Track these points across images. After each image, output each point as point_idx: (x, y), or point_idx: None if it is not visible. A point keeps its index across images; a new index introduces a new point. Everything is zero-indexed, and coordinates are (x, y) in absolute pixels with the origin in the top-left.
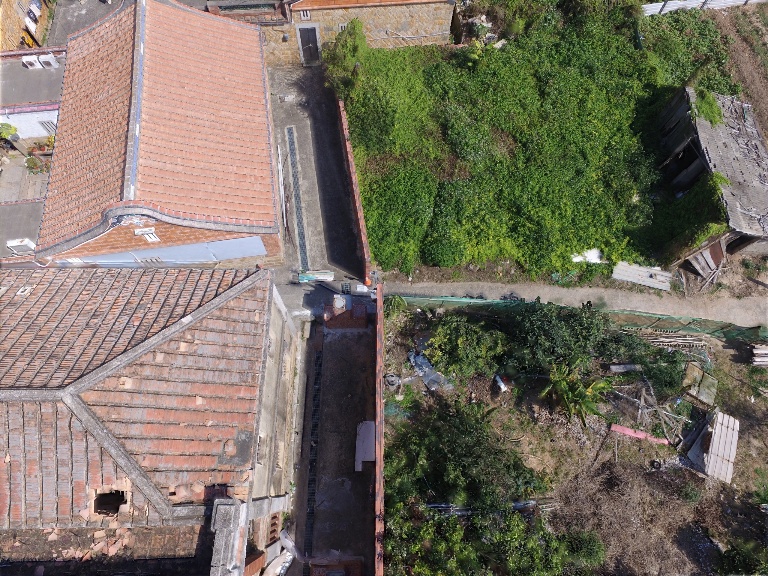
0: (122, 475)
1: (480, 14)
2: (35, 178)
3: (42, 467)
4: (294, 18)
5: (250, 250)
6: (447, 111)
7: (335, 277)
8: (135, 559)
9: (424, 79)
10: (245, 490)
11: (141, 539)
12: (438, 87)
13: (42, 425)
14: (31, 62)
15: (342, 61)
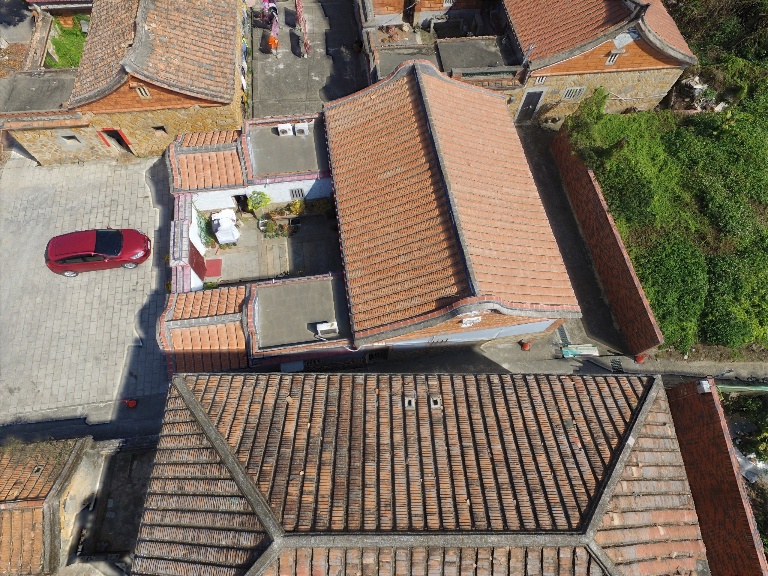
0: None
1: (692, 75)
2: (271, 242)
3: None
4: (528, 83)
5: (533, 329)
6: (702, 182)
7: (599, 352)
8: None
9: (664, 146)
10: None
11: None
12: (683, 156)
13: (560, 571)
14: (285, 130)
15: (588, 129)
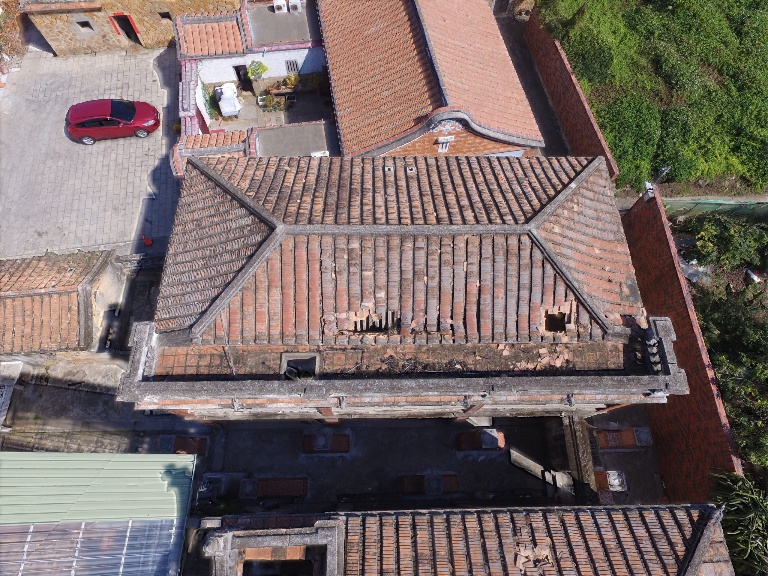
0: (571, 298)
1: None
2: (269, 115)
3: (507, 290)
4: None
5: None
6: (657, 48)
7: None
8: (577, 370)
9: (625, 22)
10: (644, 322)
11: (578, 355)
12: (642, 28)
13: (508, 255)
14: (280, 6)
15: (555, 5)
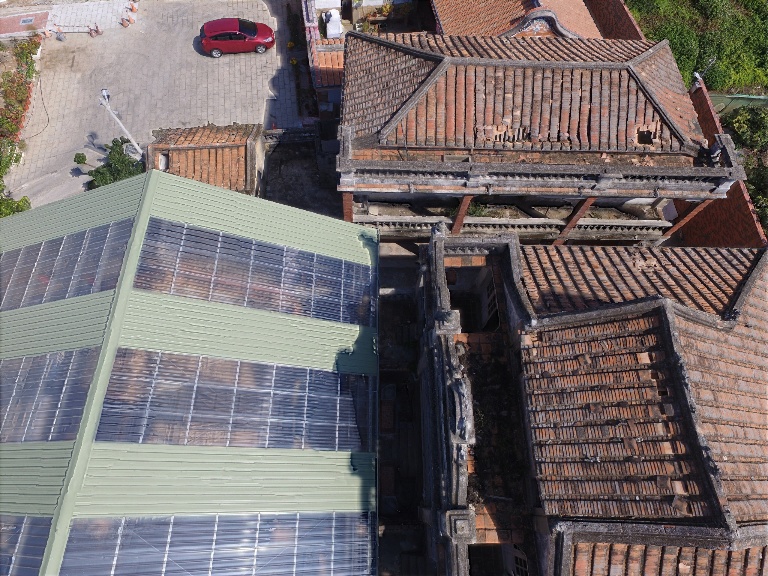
0: (657, 118)
1: None
2: None
3: (610, 111)
4: None
5: None
6: None
7: None
8: None
9: None
10: None
11: (660, 164)
12: None
13: (612, 85)
14: None
15: None
